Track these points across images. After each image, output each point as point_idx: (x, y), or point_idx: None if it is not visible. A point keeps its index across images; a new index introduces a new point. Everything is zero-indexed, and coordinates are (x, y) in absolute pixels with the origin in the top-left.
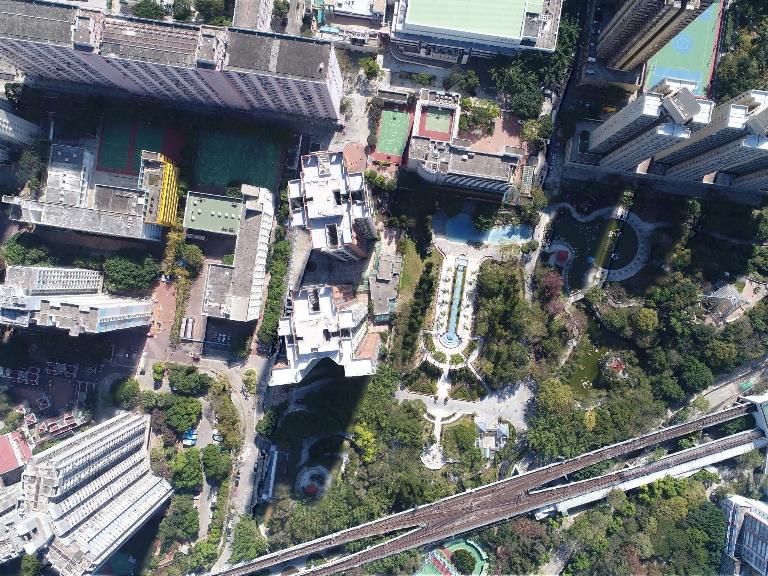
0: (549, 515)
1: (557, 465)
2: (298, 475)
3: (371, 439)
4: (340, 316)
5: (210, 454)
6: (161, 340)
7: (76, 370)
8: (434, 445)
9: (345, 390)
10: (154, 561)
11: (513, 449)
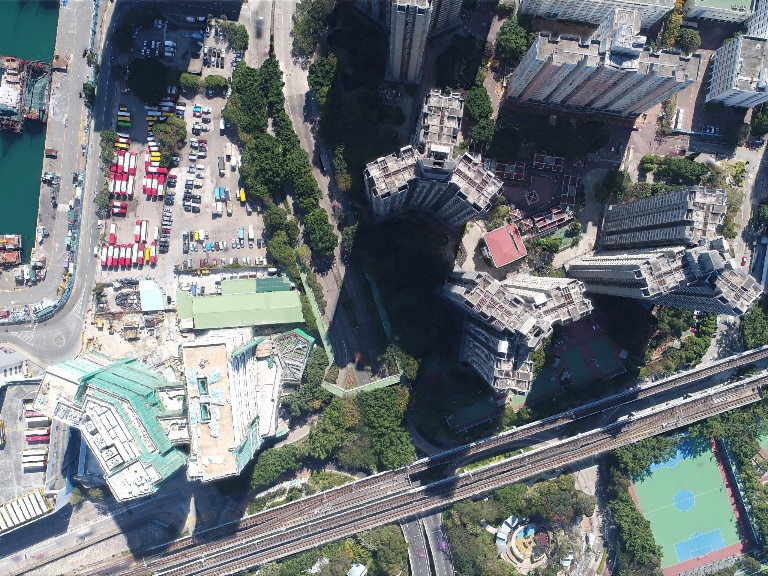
0: None
1: None
2: None
3: None
4: None
5: None
6: (646, 133)
7: (562, 164)
8: None
9: None
10: (648, 355)
11: None
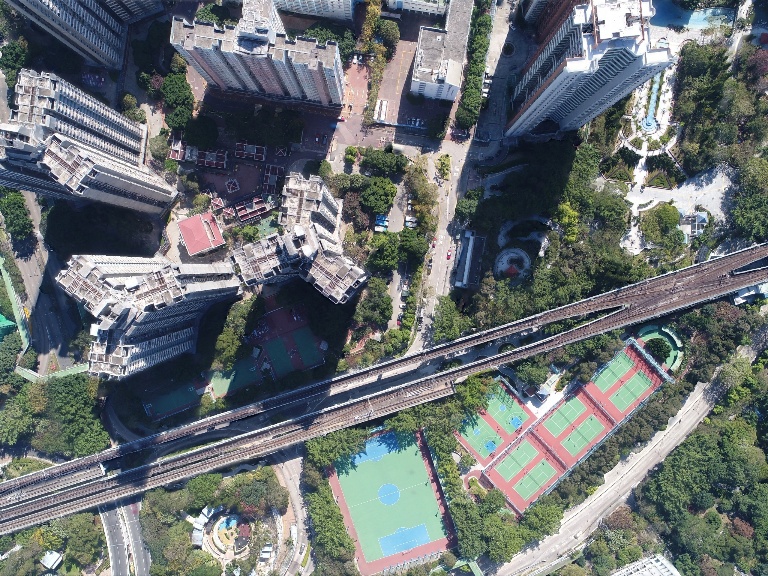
0: (746, 301)
1: (762, 245)
2: (496, 259)
3: (576, 218)
4: (641, 1)
5: (408, 235)
6: (352, 124)
7: (265, 153)
8: (633, 230)
9: (551, 167)
10: (347, 347)
11: (712, 235)
